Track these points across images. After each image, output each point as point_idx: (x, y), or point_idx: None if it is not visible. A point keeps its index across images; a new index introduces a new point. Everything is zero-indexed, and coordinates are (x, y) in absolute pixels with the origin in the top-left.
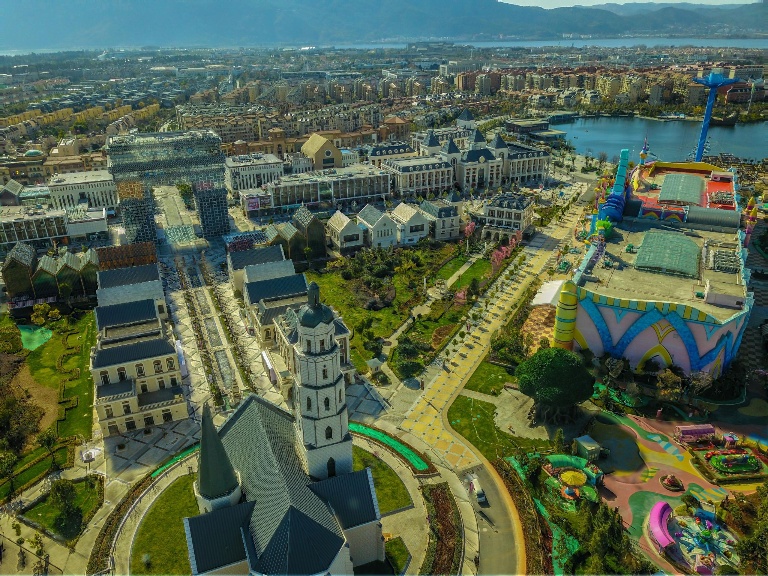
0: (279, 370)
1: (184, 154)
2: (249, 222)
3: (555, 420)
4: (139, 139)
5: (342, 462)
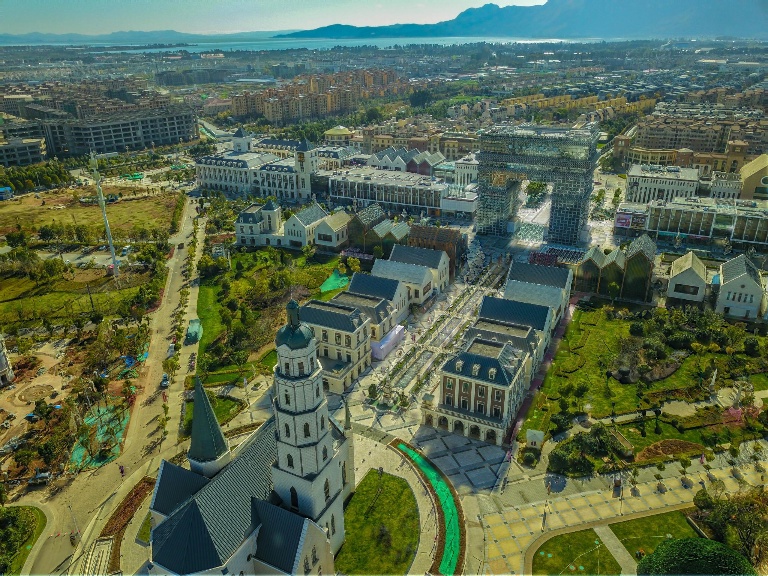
0: (436, 392)
1: (549, 152)
2: (610, 239)
3: None
4: (518, 131)
5: (304, 498)
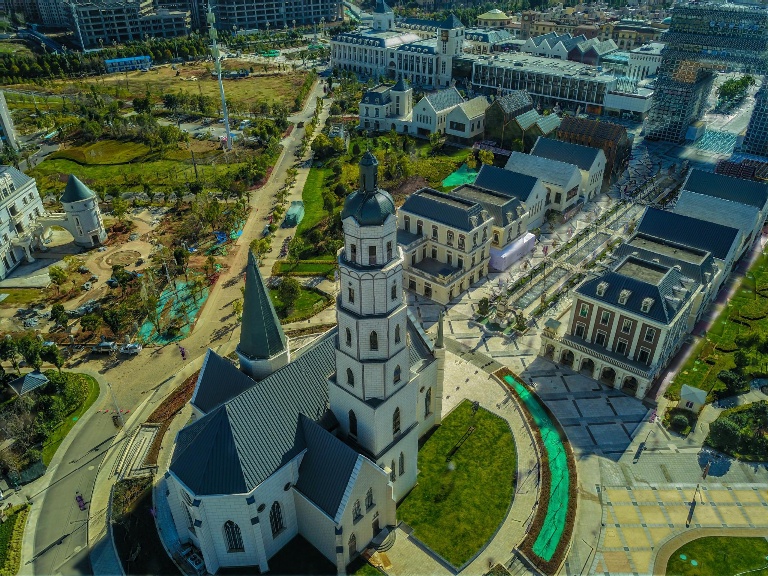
0: (564, 318)
1: (767, 33)
2: None
3: None
4: (726, 5)
5: (364, 427)
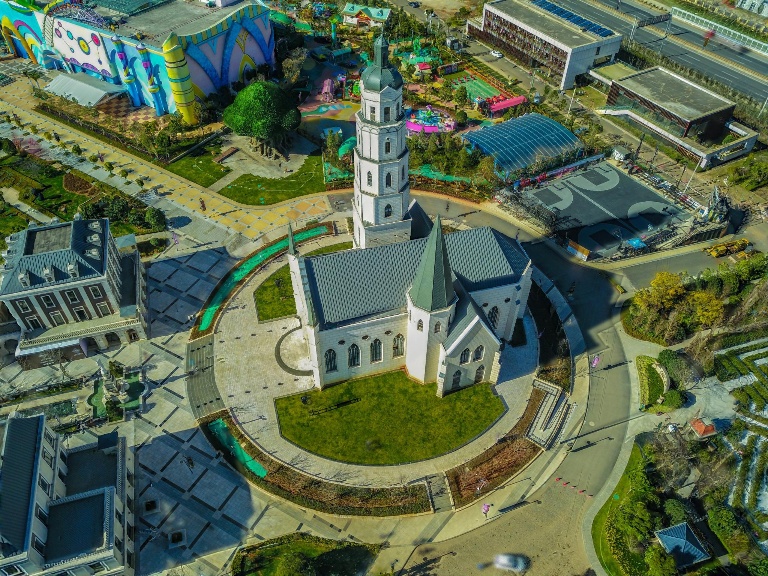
0: None
1: None
2: None
3: (288, 144)
4: None
5: None
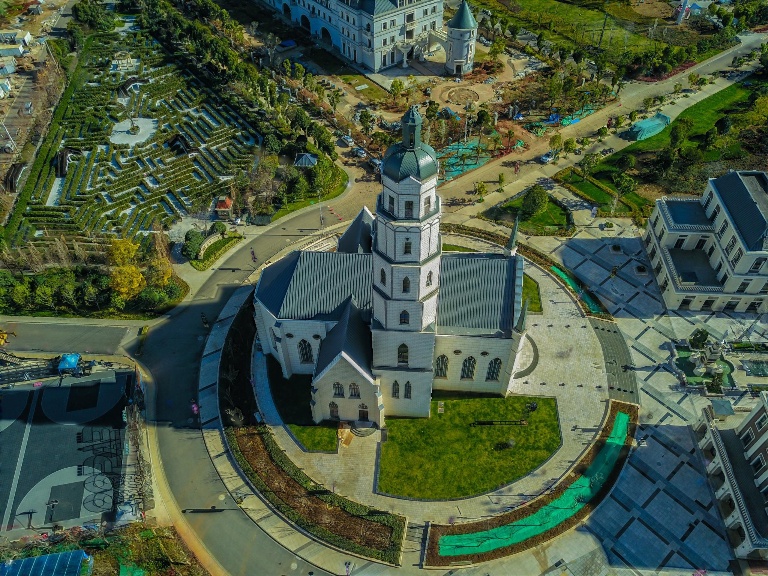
0: None
1: None
2: None
3: None
4: None
5: None
